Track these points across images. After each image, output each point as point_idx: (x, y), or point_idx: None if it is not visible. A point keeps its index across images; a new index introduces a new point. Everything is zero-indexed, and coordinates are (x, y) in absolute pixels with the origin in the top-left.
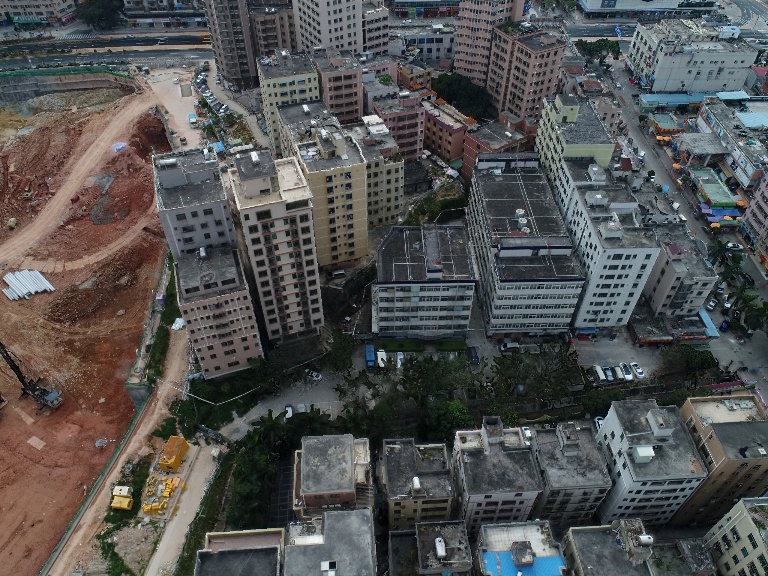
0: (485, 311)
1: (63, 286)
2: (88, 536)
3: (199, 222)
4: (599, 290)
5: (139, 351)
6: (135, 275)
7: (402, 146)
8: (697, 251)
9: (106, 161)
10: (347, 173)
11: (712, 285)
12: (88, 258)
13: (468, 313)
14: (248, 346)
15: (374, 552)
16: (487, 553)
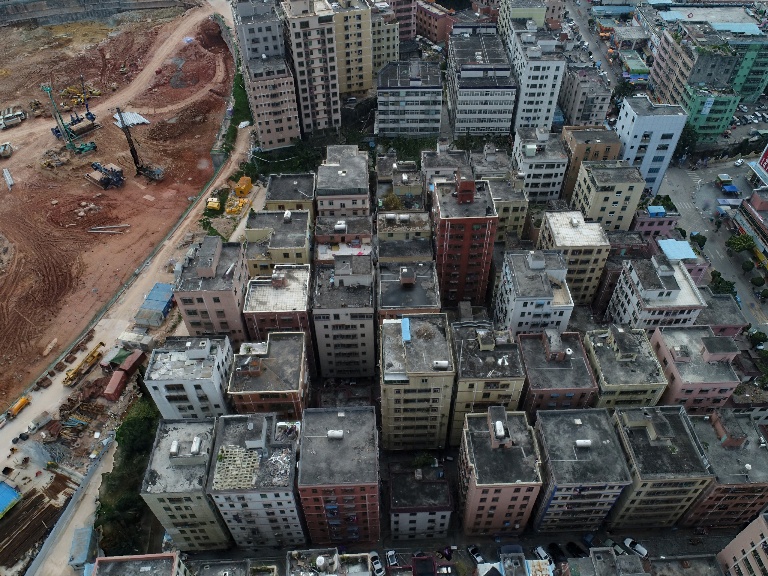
0: (453, 124)
1: (156, 121)
2: (194, 221)
3: (262, 36)
4: (528, 98)
5: (218, 137)
6: (206, 116)
7: (400, 27)
8: (601, 81)
9: (179, 49)
10: (358, 15)
11: (609, 100)
12: (171, 107)
13: (439, 117)
14: (291, 126)
15: (367, 172)
16: (432, 185)
